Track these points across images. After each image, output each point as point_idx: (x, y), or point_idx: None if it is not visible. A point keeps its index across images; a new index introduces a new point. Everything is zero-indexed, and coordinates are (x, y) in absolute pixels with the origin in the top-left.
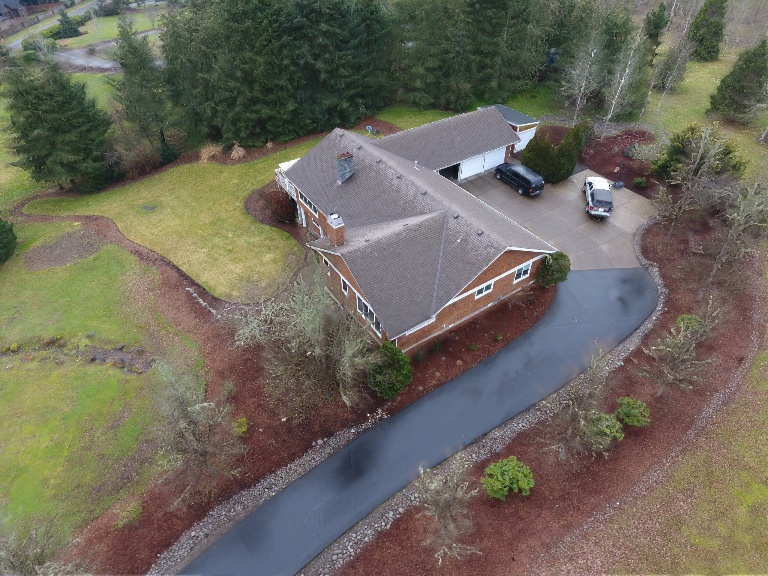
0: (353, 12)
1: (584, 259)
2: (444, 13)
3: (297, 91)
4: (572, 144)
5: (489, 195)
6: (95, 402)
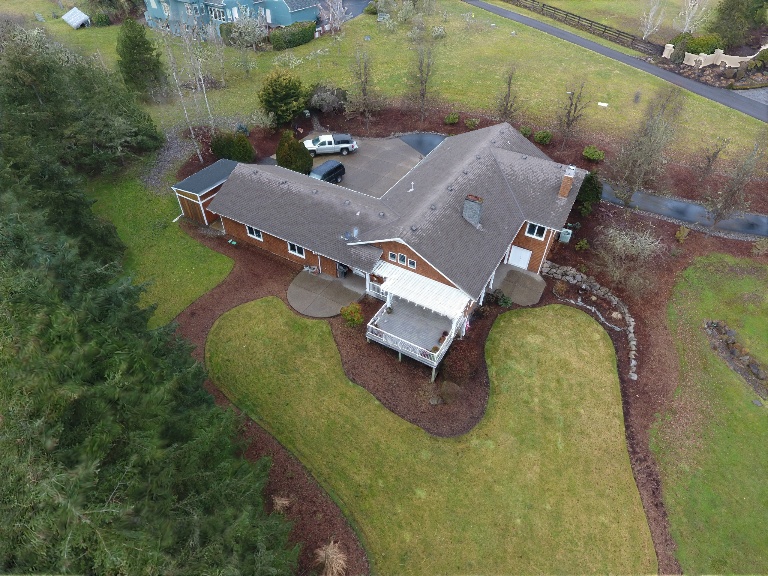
0: None
1: (409, 153)
2: None
3: None
4: None
5: None
6: (767, 323)
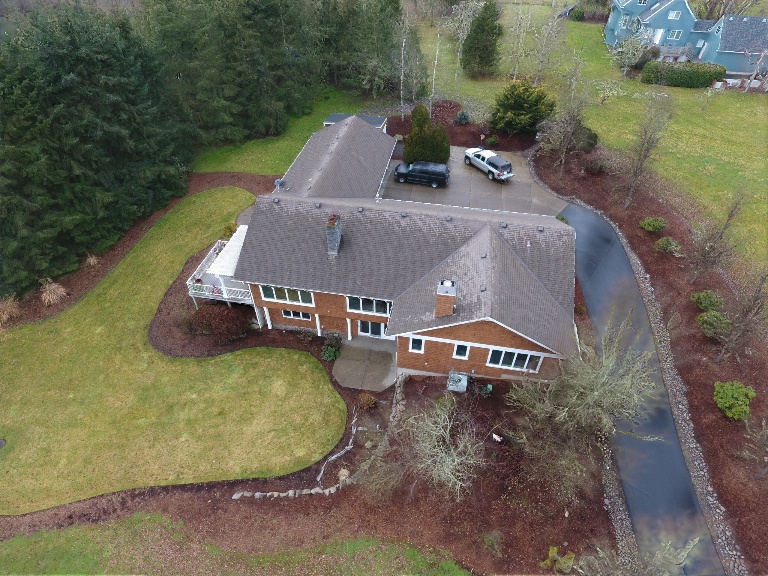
0: (122, 51)
1: None
2: (223, 31)
3: (97, 175)
4: (442, 128)
5: (415, 200)
6: None
